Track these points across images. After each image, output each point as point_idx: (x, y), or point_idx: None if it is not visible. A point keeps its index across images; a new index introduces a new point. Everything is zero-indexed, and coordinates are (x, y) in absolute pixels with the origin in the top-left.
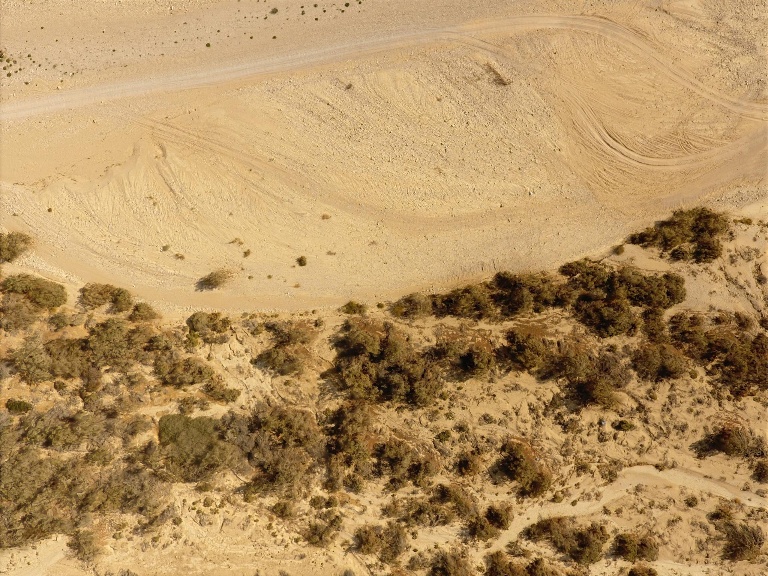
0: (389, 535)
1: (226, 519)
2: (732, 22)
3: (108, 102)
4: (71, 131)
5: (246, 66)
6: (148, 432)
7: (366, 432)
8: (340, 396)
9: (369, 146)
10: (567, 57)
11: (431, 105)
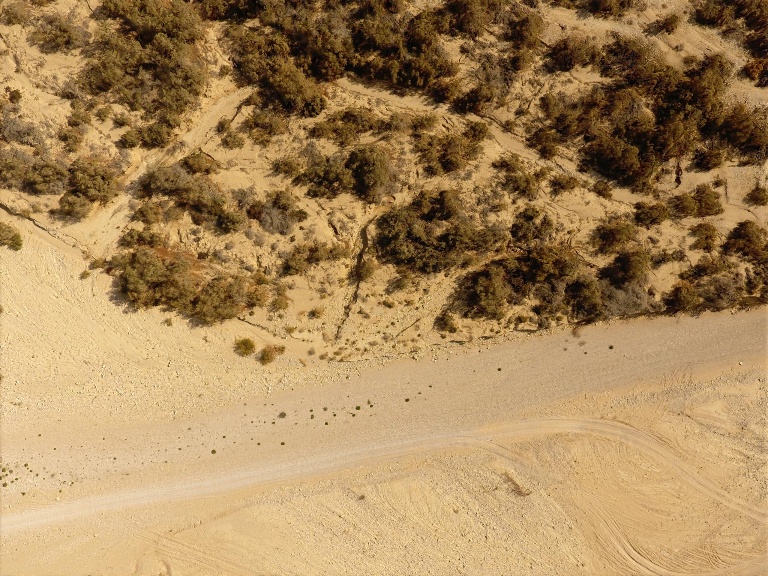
0: None
1: None
2: (758, 429)
3: (109, 514)
4: (70, 546)
5: (253, 473)
6: None
7: None
8: None
9: (384, 562)
10: (588, 466)
11: (448, 518)
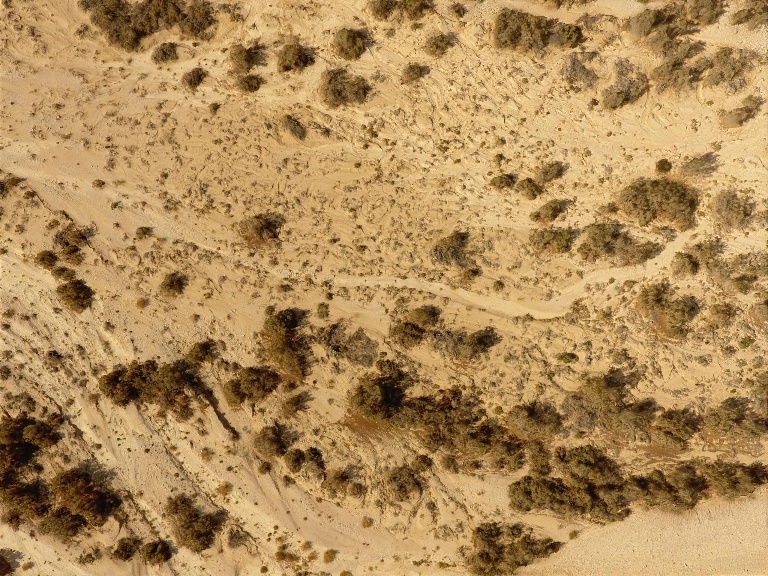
0: None
1: None
2: None
3: None
4: None
5: None
6: None
7: None
8: None
9: None
10: None
11: None
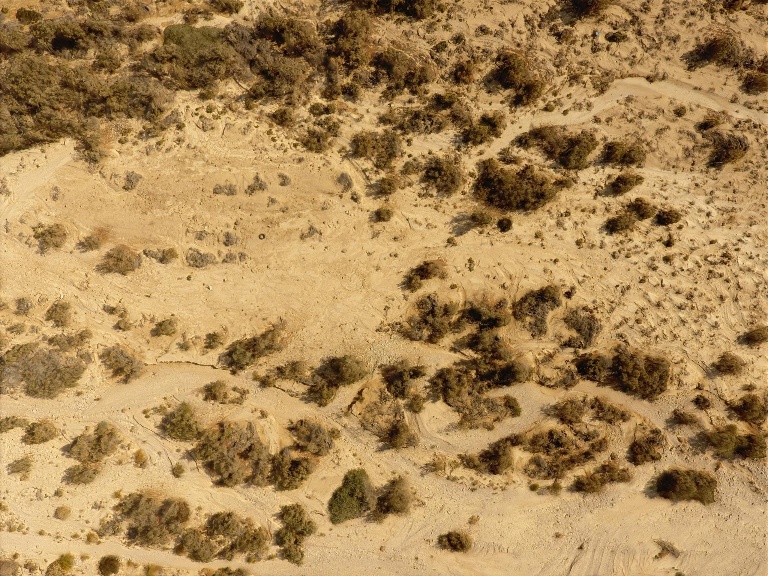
0: (385, 140)
1: (228, 123)
2: None
3: None
4: None
5: None
6: (153, 41)
7: (365, 41)
8: (341, 9)
9: None
10: None
11: None
